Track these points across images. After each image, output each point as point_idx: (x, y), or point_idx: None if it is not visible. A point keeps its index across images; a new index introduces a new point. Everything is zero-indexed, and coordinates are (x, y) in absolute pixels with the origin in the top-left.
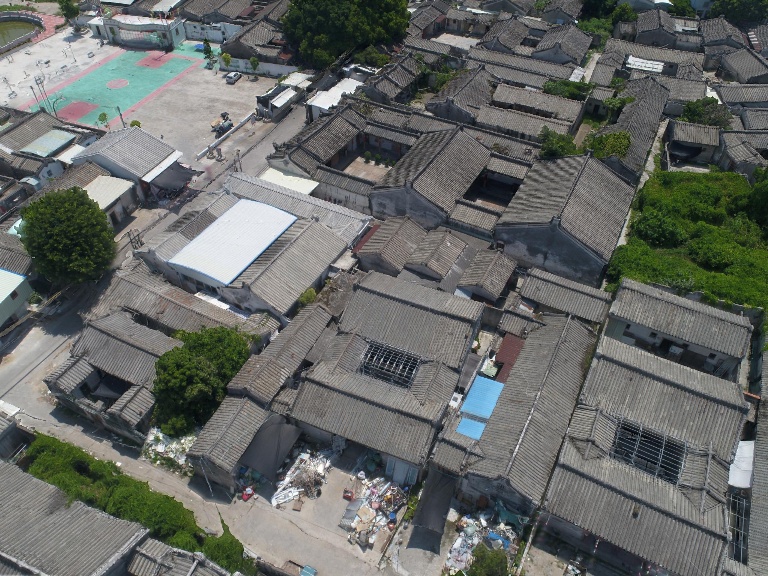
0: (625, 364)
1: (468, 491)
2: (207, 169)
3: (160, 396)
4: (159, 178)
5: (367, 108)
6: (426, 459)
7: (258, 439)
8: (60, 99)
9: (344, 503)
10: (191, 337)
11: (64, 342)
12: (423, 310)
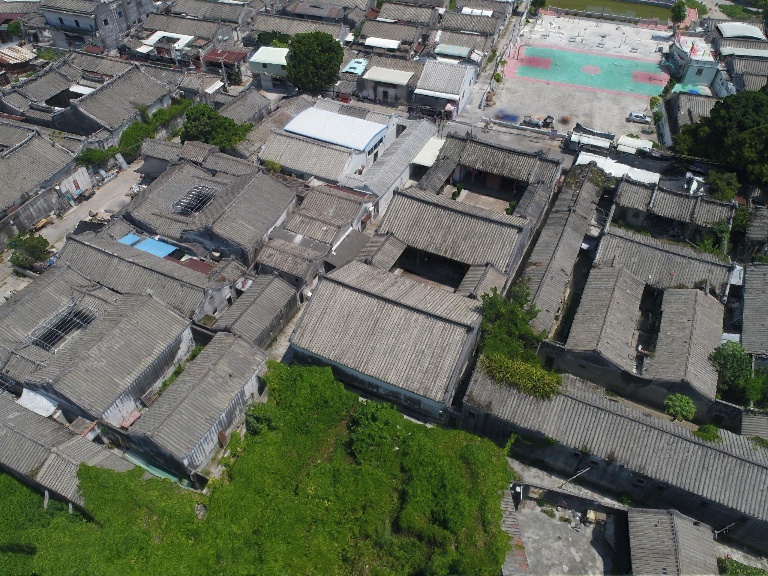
0: None
1: None
2: (468, 127)
3: None
4: (422, 96)
5: (576, 183)
6: None
7: (162, 162)
8: (528, 46)
9: None
10: (232, 119)
11: None
12: None
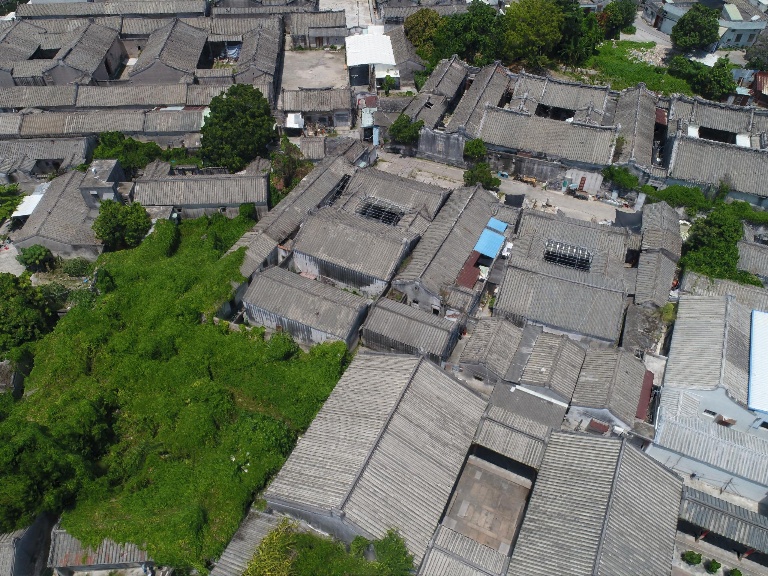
0: None
1: None
2: None
3: None
4: None
5: None
6: None
7: None
8: None
9: None
10: None
11: None
12: None
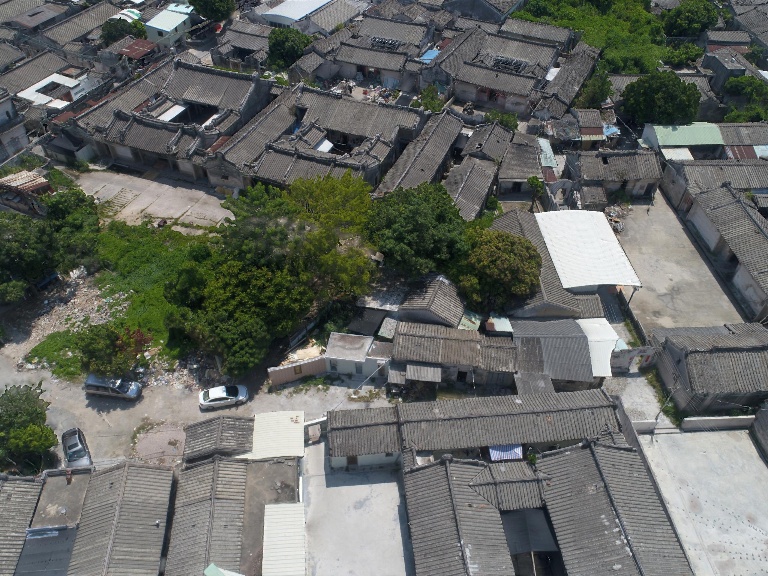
0: (501, 35)
1: (423, 86)
2: None
3: (270, 53)
4: None
5: None
6: (402, 68)
7: (320, 68)
8: None
9: (363, 95)
10: None
11: (209, 53)
12: (401, 24)
